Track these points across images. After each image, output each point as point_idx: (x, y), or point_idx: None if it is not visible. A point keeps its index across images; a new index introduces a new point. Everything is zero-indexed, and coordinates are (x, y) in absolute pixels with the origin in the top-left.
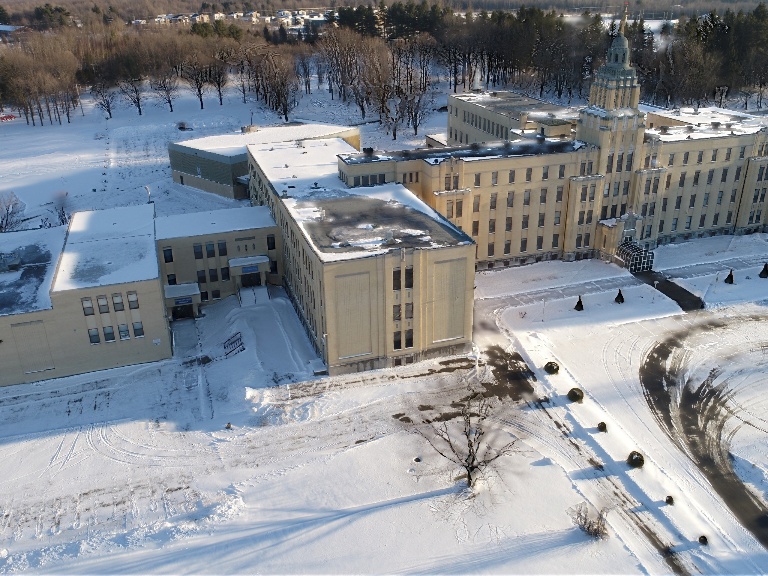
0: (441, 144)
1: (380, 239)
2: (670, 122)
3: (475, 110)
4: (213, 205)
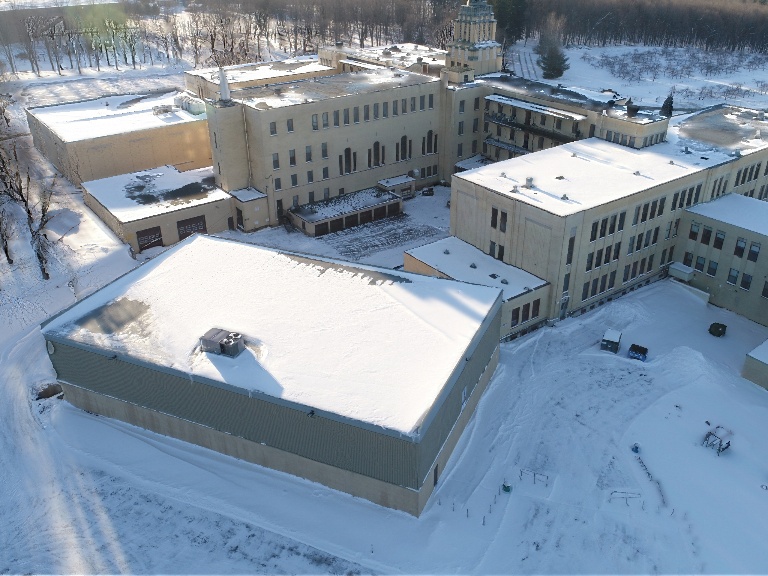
0: (195, 207)
1: (763, 121)
2: (255, 84)
3: (345, 103)
4: (536, 384)
